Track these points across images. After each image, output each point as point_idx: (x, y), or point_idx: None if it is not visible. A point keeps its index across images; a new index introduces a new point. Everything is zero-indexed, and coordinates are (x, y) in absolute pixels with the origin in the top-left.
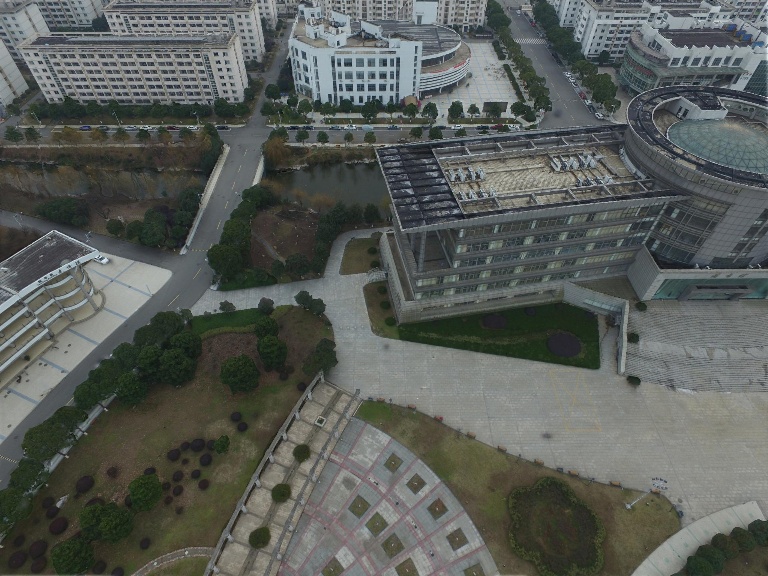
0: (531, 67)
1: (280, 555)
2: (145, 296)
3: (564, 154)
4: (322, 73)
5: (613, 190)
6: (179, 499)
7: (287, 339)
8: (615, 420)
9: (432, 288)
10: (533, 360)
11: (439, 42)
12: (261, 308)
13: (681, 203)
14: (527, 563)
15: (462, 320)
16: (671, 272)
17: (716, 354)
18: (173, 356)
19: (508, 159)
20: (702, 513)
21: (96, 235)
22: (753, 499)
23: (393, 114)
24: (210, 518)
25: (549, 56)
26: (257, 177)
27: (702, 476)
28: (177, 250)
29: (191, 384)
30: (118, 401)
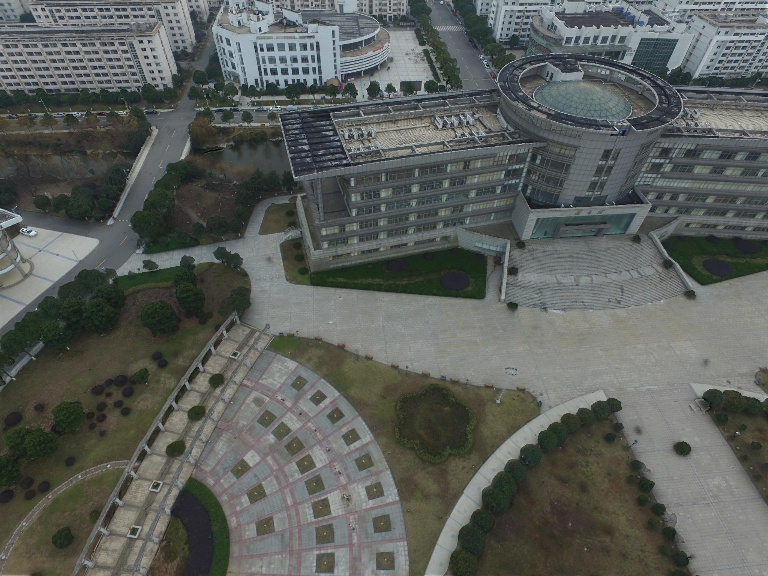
0: (445, 50)
1: (193, 460)
2: (72, 262)
3: (448, 115)
4: (246, 58)
5: (486, 142)
6: (102, 425)
7: (207, 290)
8: (494, 337)
9: (336, 236)
10: (428, 295)
11: (359, 28)
12: (182, 264)
13: (541, 150)
14: (409, 450)
15: (368, 266)
16: (540, 211)
17: (582, 280)
18: (95, 304)
19: (399, 120)
20: (558, 402)
21: (24, 212)
22: (601, 389)
23: (317, 96)
24: (131, 438)
25: (466, 41)
26: (184, 155)
27: (561, 375)
28: (104, 221)
29: (116, 332)
30: (46, 351)
